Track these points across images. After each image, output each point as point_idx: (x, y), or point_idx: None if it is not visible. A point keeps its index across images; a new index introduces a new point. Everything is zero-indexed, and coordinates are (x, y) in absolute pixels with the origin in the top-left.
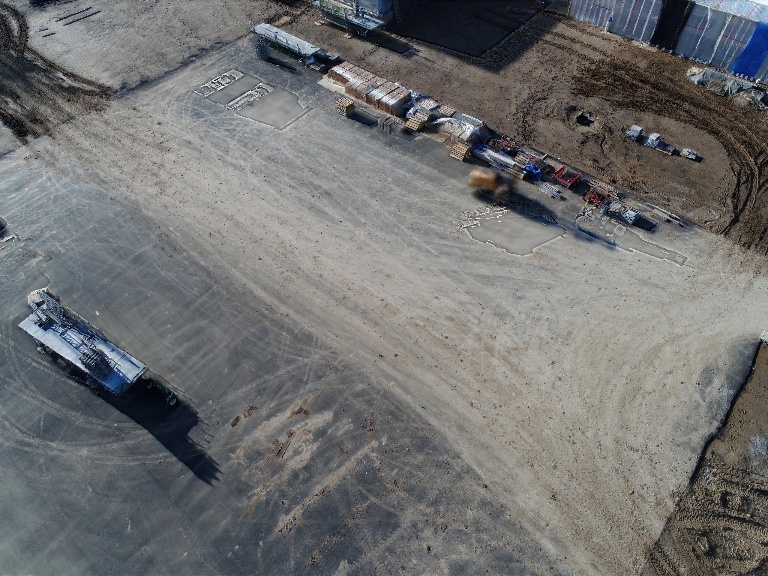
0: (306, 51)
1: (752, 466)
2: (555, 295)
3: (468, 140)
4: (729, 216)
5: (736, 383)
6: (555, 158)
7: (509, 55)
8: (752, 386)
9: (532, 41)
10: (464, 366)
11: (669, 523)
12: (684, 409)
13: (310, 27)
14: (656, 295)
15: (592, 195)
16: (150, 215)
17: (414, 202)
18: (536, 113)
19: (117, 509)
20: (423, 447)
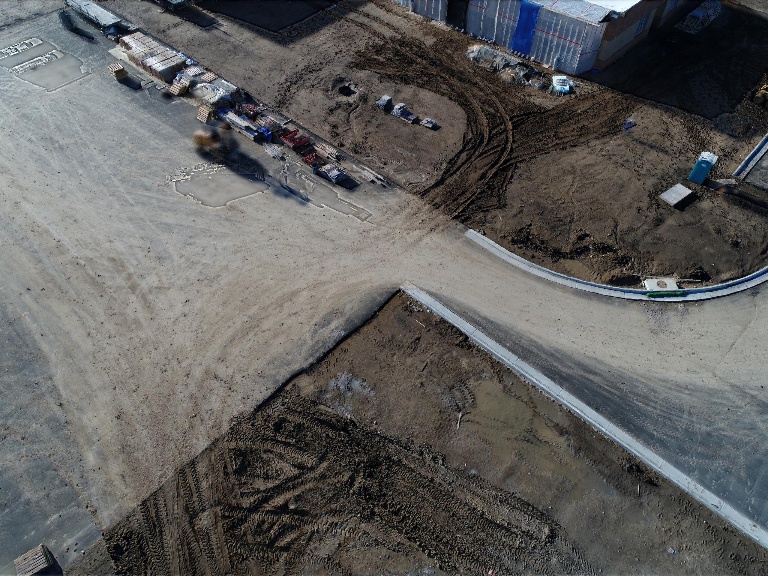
0: (106, 22)
1: (324, 398)
2: (224, 243)
3: (213, 103)
4: (435, 179)
5: (352, 325)
6: (298, 123)
7: (306, 31)
8: (367, 329)
9: (335, 19)
10: (101, 301)
11: (214, 443)
12: (288, 346)
13: (130, 2)
14: (322, 246)
15: (310, 156)
16: None
17: (139, 158)
18: (303, 83)
19: None
20: (22, 369)
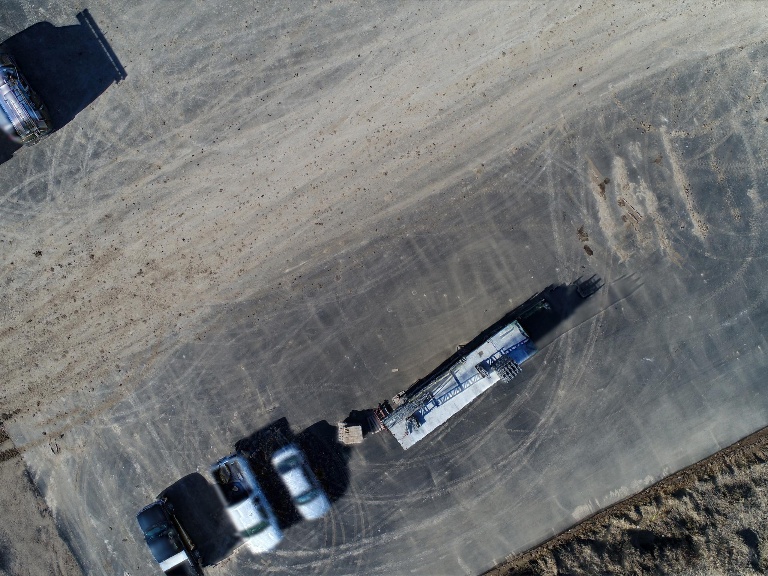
0: None
1: None
2: None
3: None
4: None
5: None
6: None
7: None
8: None
9: None
10: (621, 6)
11: None
12: None
13: None
14: None
15: None
16: (251, 293)
17: None
18: None
19: (629, 368)
20: (685, 86)
